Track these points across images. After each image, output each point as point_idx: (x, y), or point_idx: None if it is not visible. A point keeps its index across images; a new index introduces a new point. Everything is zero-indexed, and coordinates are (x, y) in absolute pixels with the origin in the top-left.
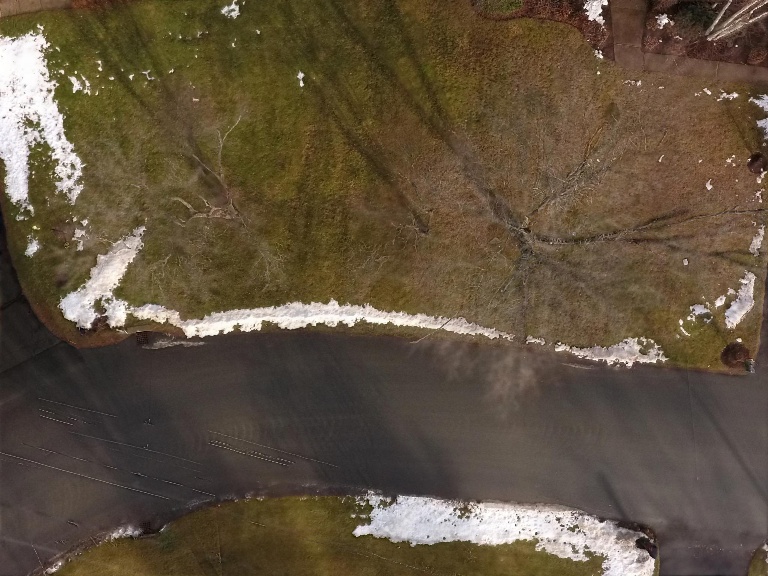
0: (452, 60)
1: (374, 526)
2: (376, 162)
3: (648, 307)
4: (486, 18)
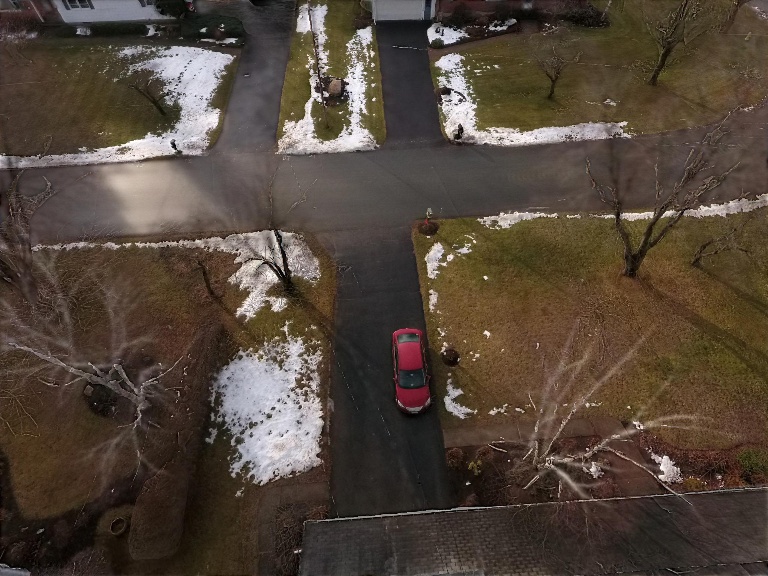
0: (763, 398)
1: (618, 126)
2: (762, 305)
3: (504, 245)
4: (761, 444)
